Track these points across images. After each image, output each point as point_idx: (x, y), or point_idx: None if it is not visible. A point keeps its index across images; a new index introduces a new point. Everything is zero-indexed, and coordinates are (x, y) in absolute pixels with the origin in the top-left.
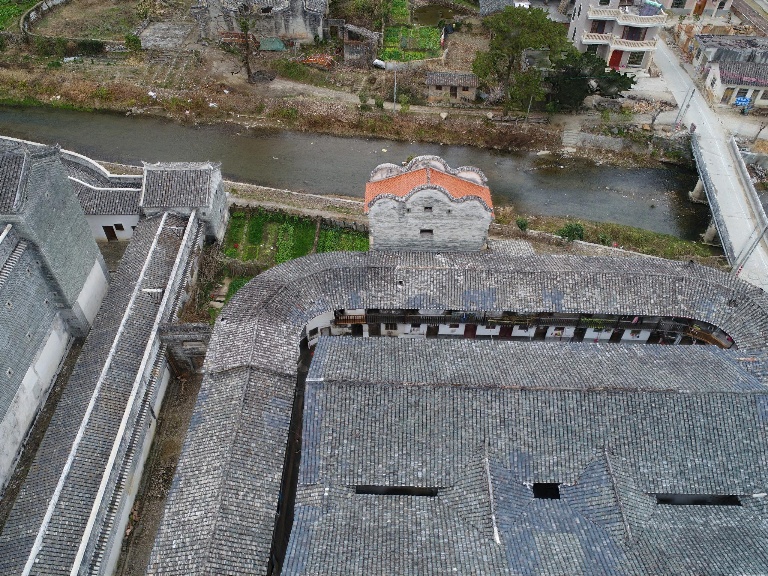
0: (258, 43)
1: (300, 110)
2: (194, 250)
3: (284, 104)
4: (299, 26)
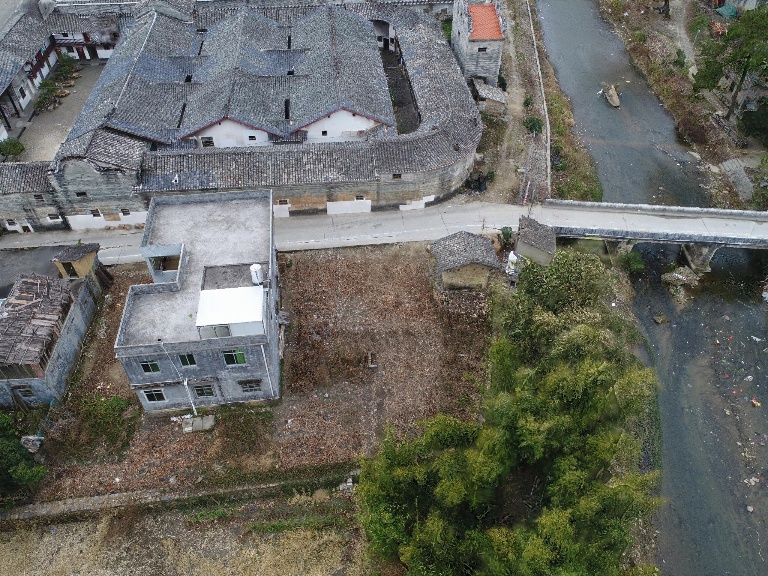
0: (722, 6)
1: (648, 41)
2: (434, 2)
3: (648, 33)
4: (752, 4)
